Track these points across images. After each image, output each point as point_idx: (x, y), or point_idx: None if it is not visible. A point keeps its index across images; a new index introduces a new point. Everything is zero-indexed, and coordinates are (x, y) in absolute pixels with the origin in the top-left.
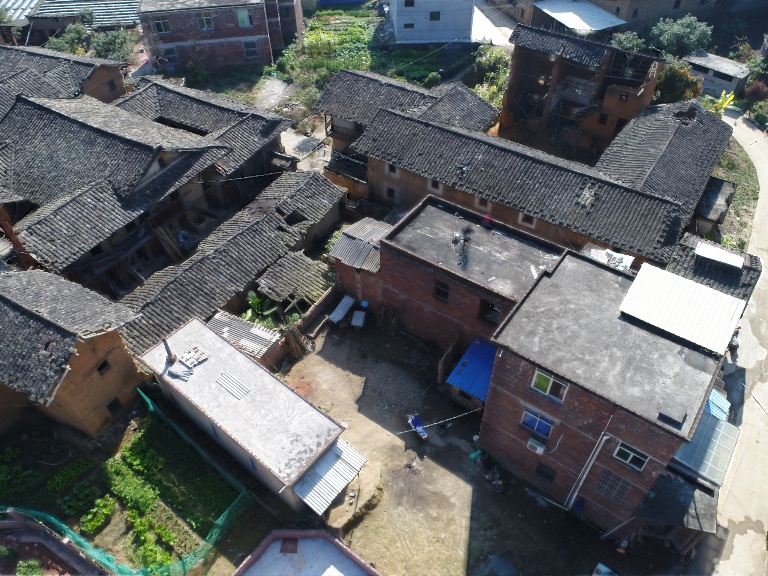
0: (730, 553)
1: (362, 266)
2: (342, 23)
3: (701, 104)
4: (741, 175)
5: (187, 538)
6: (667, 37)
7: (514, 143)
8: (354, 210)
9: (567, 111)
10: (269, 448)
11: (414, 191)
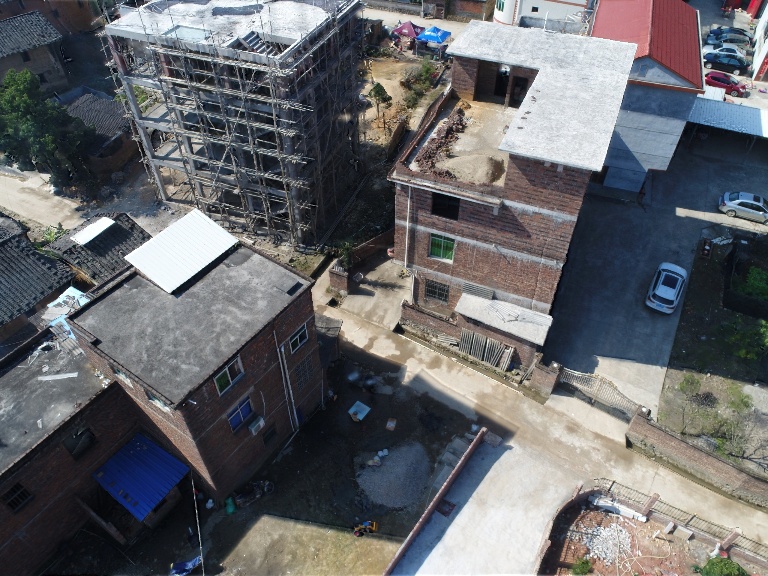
0: (340, 330)
1: None
2: None
3: None
4: None
5: None
6: None
7: None
8: None
9: None
10: None
11: None
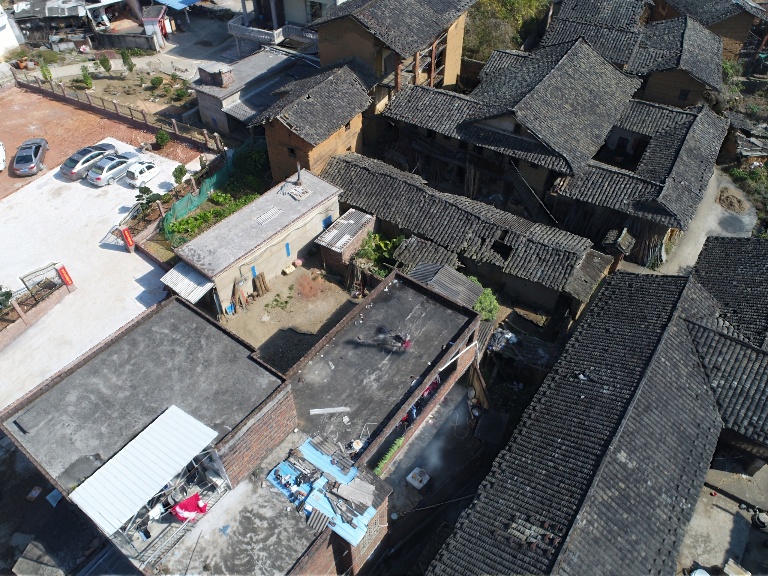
0: None
1: None
2: None
3: None
4: None
5: (192, 237)
6: None
7: (699, 468)
8: None
9: None
10: (208, 239)
11: None
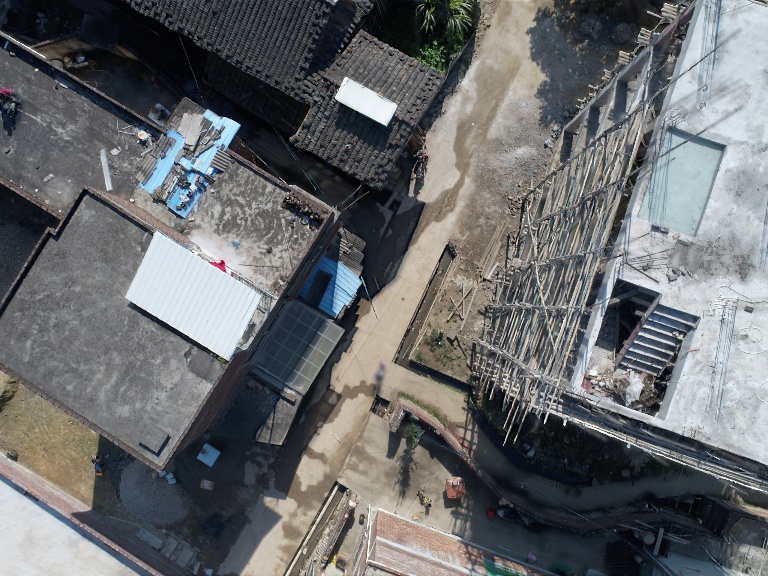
0: (335, 417)
1: None
2: None
3: None
4: None
5: None
6: None
7: None
8: None
9: None
10: None
11: None
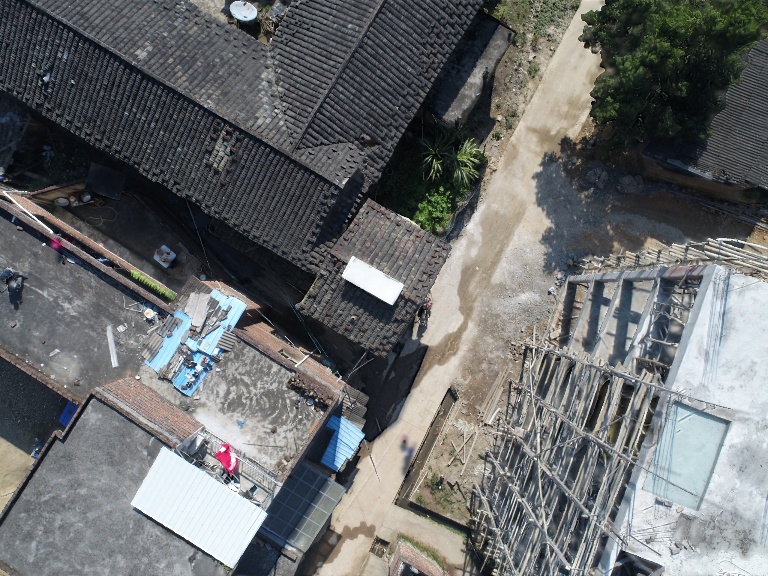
0: (335, 557)
1: None
2: None
3: None
4: None
5: None
6: None
7: None
8: None
9: None
10: None
11: None
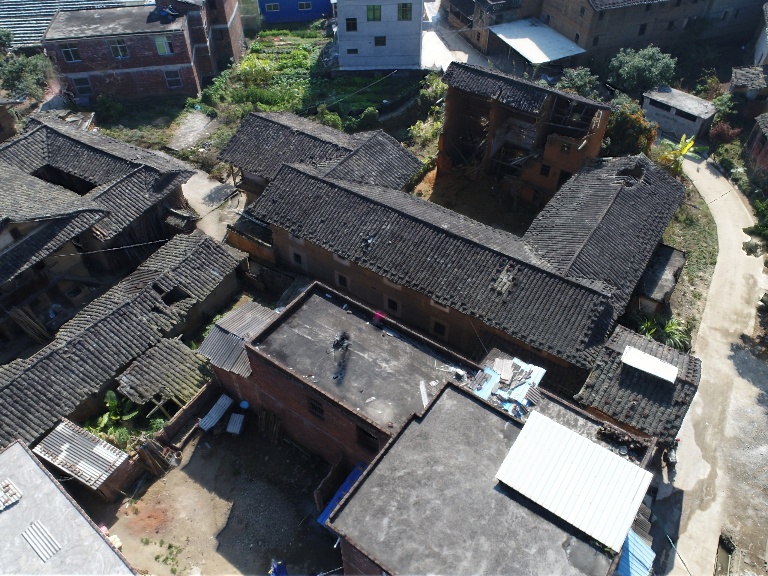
0: None
1: (232, 368)
2: (286, 45)
3: (660, 148)
4: (699, 233)
5: None
6: (627, 70)
7: (435, 205)
8: (255, 278)
9: (509, 157)
10: None
11: (321, 259)
